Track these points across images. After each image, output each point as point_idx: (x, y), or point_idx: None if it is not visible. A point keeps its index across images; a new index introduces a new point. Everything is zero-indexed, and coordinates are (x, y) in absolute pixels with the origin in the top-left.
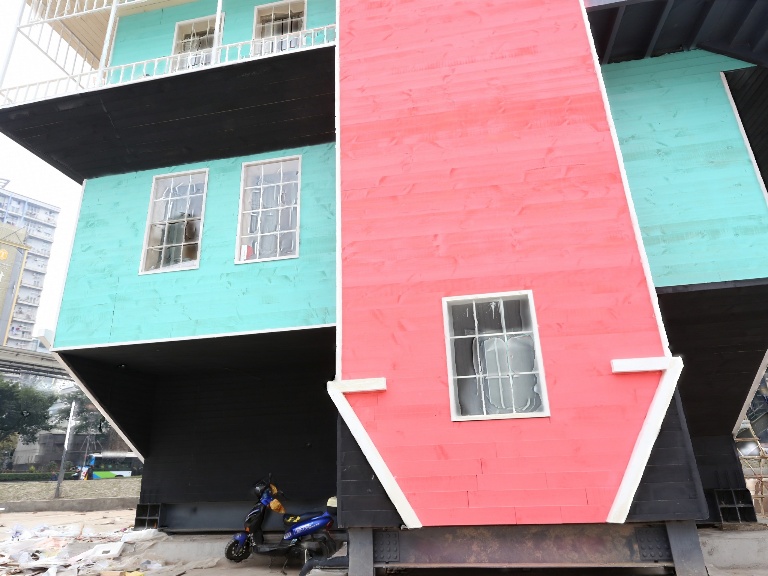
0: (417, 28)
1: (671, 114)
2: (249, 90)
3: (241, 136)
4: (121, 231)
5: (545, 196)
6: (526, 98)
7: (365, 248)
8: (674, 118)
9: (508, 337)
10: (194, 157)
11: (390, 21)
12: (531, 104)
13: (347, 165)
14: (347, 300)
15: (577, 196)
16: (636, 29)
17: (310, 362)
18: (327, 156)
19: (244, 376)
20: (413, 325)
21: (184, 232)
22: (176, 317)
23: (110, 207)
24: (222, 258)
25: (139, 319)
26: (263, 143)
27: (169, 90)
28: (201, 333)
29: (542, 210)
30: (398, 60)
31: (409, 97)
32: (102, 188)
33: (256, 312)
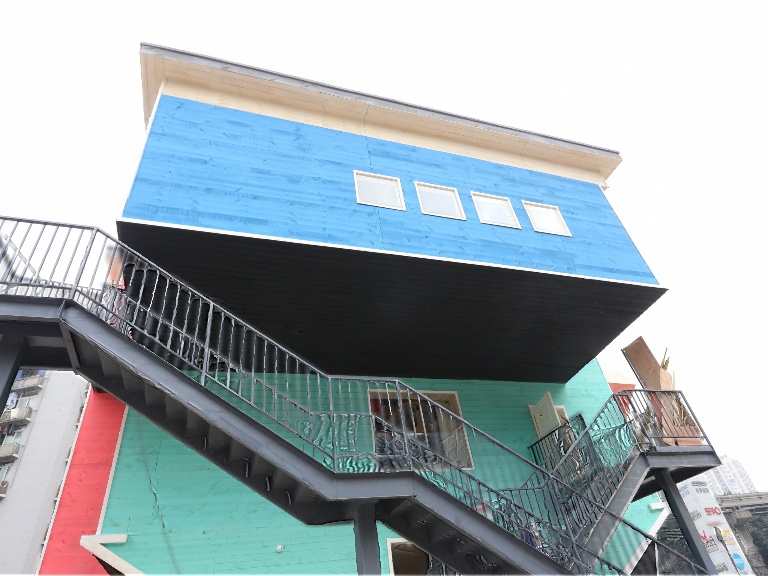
0: None
1: None
2: None
3: None
4: None
5: None
6: None
7: None
8: None
9: None
10: None
11: None
12: None
13: None
14: None
15: None
16: None
17: None
18: None
19: None
20: None
21: None
22: None
23: None
24: None
25: None
26: None
27: None
28: None
29: None
30: None
31: None
32: None
33: None
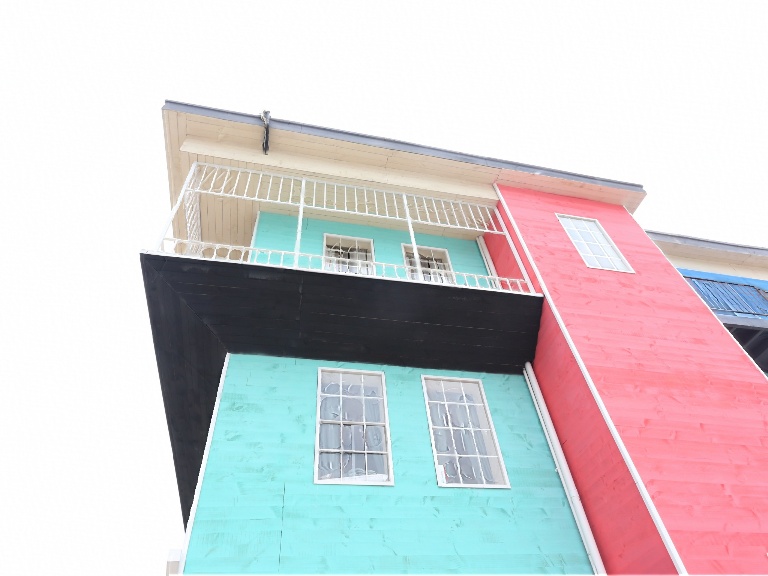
0: (609, 303)
1: None
2: (453, 311)
3: (427, 349)
4: (282, 423)
5: None
6: (722, 377)
7: (666, 488)
8: None
9: None
10: (369, 358)
11: (585, 292)
12: (728, 382)
13: (607, 401)
14: (679, 546)
15: None
16: None
17: None
18: (507, 386)
19: None
20: None
21: None
22: (376, 549)
23: (264, 391)
24: (421, 476)
25: (322, 547)
26: (445, 360)
27: (378, 291)
28: None
29: None
30: (606, 323)
31: (631, 354)
32: (252, 367)
33: (479, 552)
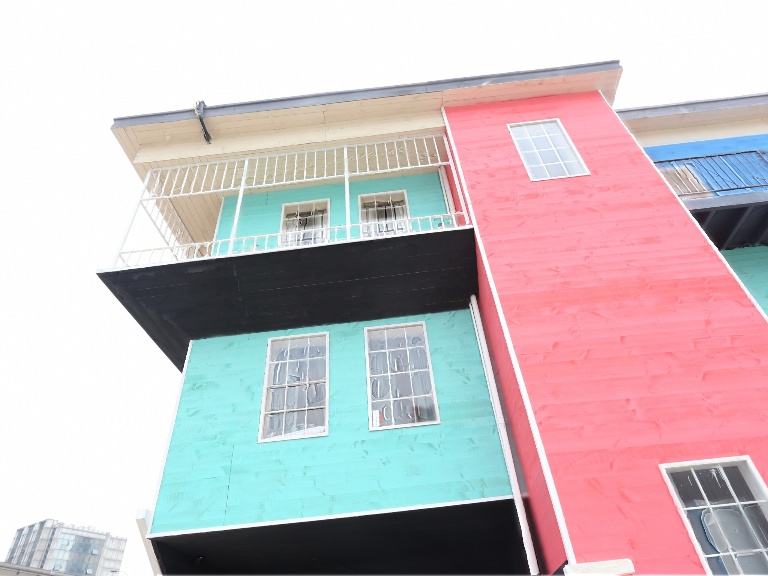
0: (546, 218)
1: (763, 295)
2: (383, 262)
3: (366, 302)
4: (234, 394)
5: (721, 363)
6: (667, 278)
7: (558, 412)
8: (767, 299)
9: (743, 507)
10: (314, 321)
11: (520, 212)
12: (674, 283)
13: (515, 331)
14: (555, 468)
15: (751, 363)
16: (714, 228)
17: (426, 547)
18: (451, 323)
19: (333, 568)
20: (637, 495)
21: (306, 396)
22: (307, 492)
23: (220, 369)
24: (354, 424)
25: (261, 495)
26: (386, 309)
27: (305, 259)
28: (339, 511)
29: (724, 376)
30: (537, 243)
31: (557, 273)
32: (211, 349)
33: (402, 485)
